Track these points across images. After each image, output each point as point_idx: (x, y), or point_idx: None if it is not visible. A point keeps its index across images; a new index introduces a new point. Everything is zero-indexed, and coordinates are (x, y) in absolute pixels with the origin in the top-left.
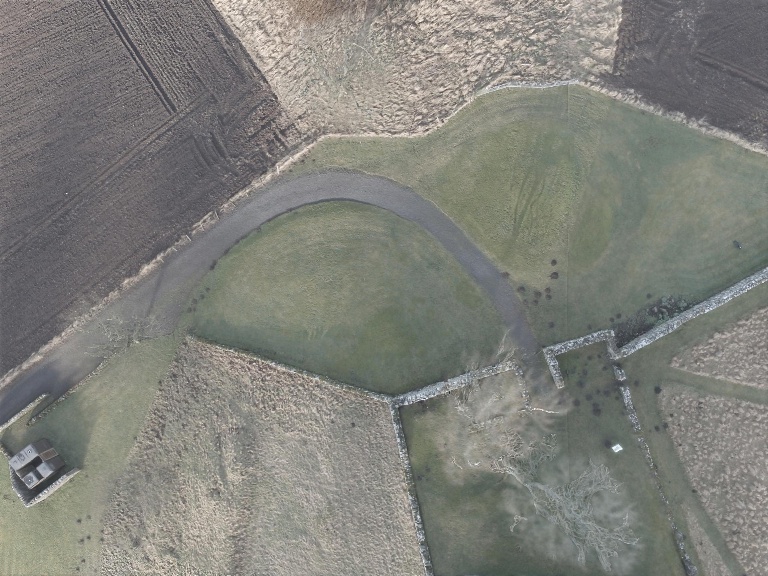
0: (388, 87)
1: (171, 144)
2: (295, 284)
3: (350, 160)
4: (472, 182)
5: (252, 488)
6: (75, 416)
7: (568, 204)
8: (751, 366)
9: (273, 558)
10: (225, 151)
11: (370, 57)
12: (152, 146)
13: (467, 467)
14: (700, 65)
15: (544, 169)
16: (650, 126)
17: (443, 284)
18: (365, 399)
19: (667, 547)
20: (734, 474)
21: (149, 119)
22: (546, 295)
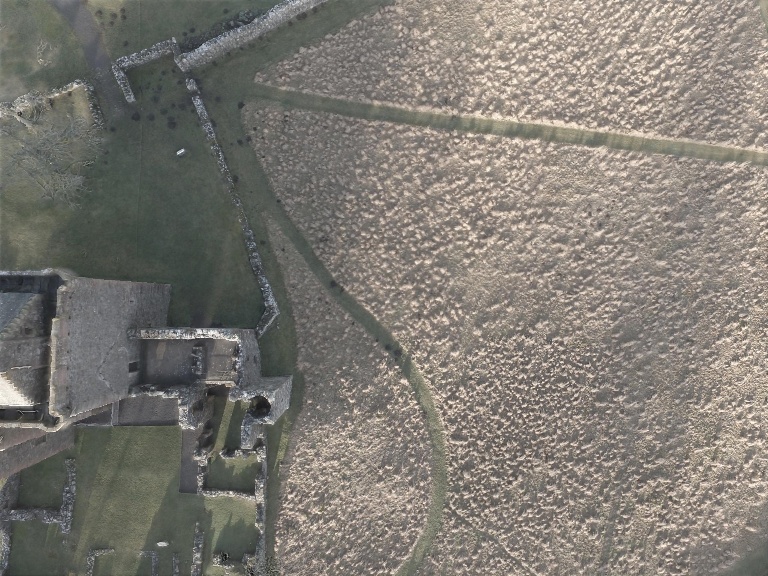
0: None
1: None
2: None
3: None
4: None
5: None
6: None
7: None
8: (340, 79)
9: None
10: None
11: None
12: None
13: None
14: None
15: None
16: None
17: (31, 19)
18: None
19: (235, 246)
20: (320, 183)
21: None
22: (121, 15)
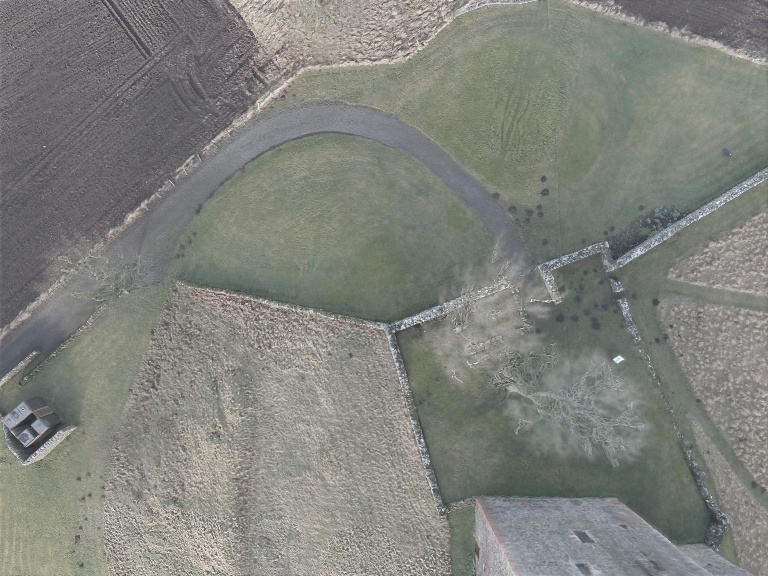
0: (365, 14)
1: (148, 89)
2: (283, 220)
3: (331, 92)
4: (456, 104)
5: (252, 429)
6: (68, 372)
7: (555, 118)
8: (748, 273)
9: (278, 498)
10: (204, 92)
11: None
12: (129, 92)
13: (468, 389)
14: None
15: (528, 84)
16: (633, 37)
17: (433, 210)
18: (361, 328)
19: (674, 455)
20: (737, 381)
21: (124, 65)
22: (538, 212)
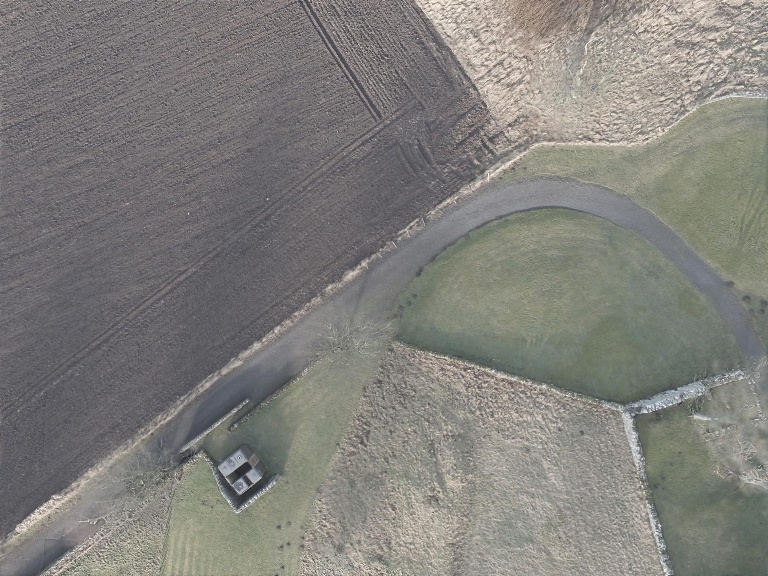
0: (606, 96)
1: (376, 151)
2: (510, 291)
3: (564, 168)
4: (695, 191)
5: (471, 495)
6: (276, 422)
7: None
8: None
9: (493, 566)
10: (431, 158)
11: (590, 66)
12: (356, 152)
13: (701, 476)
14: None
15: None
16: None
17: (663, 292)
18: (594, 407)
19: None
20: None
21: (354, 125)
22: None
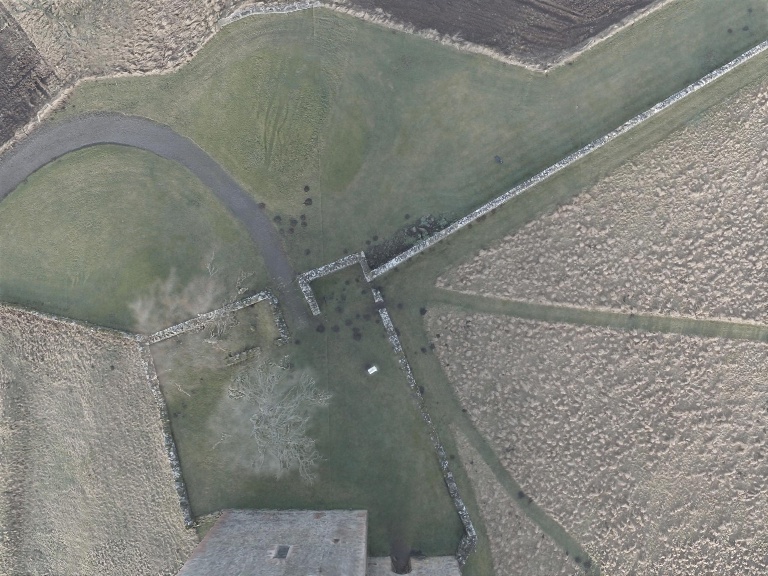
0: (136, 24)
1: None
2: (58, 232)
3: (108, 103)
4: (223, 114)
5: (24, 442)
6: None
7: (316, 128)
8: (520, 281)
9: (49, 511)
10: None
11: None
12: None
13: (225, 401)
14: None
15: (287, 93)
16: (402, 45)
17: (203, 220)
18: (122, 341)
19: (429, 467)
20: (505, 391)
21: None
22: (301, 222)
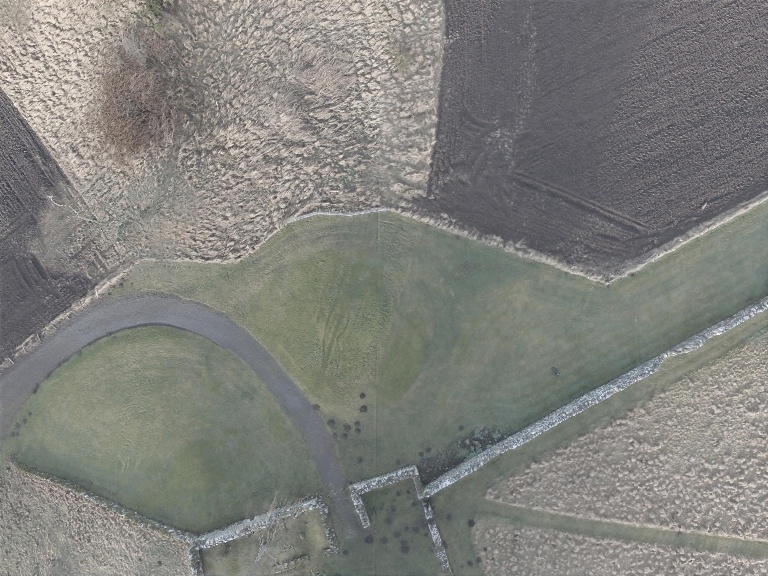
0: (200, 212)
1: None
2: (111, 412)
3: (167, 284)
4: (283, 311)
5: None
6: None
7: (375, 337)
8: (570, 495)
9: None
10: (46, 272)
11: (180, 182)
12: None
13: None
14: (518, 186)
15: (349, 302)
16: (465, 251)
17: (256, 414)
18: (171, 537)
19: None
20: None
21: None
22: (355, 429)
